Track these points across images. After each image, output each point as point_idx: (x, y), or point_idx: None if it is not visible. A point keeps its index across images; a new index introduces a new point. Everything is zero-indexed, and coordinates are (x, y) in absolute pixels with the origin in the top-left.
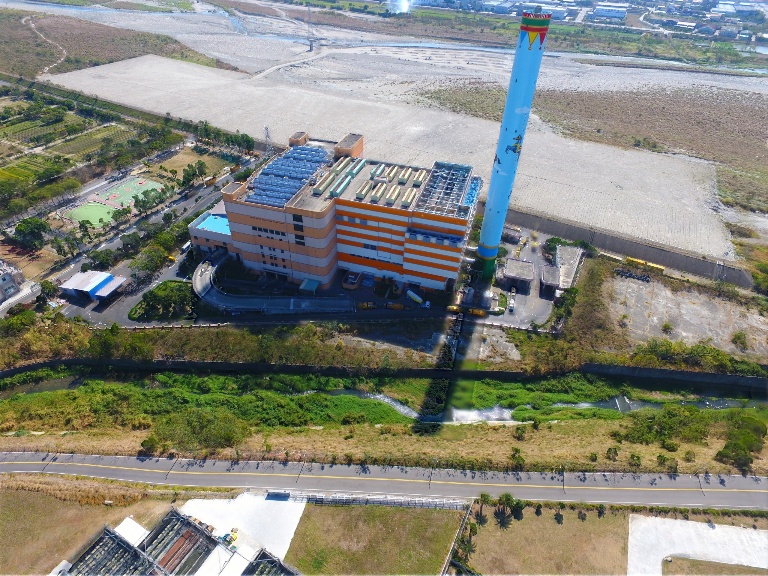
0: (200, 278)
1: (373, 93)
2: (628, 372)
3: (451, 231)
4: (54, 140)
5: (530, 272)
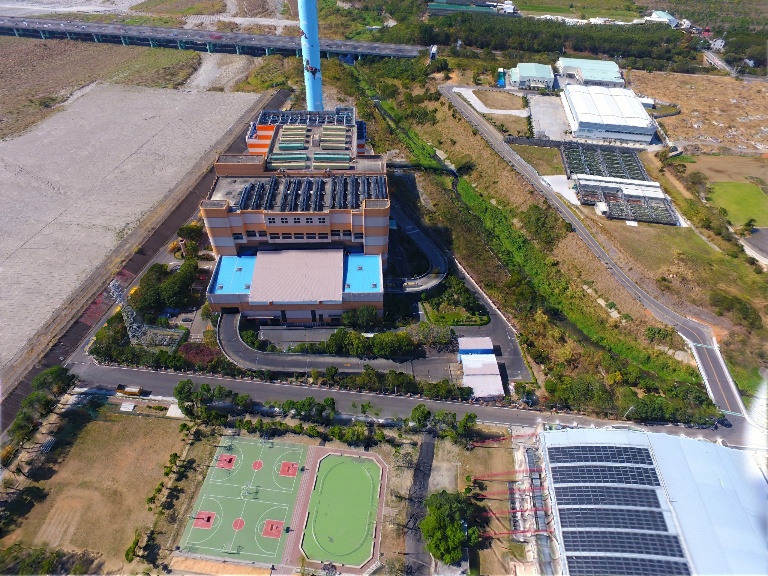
0: (425, 284)
1: None
2: None
3: None
4: None
5: None
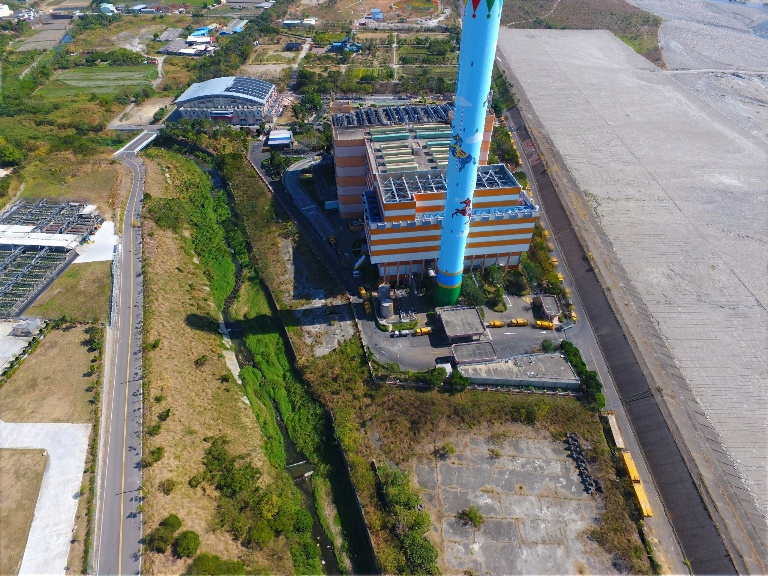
0: (305, 162)
1: None
2: None
3: None
4: (412, 63)
5: (463, 332)
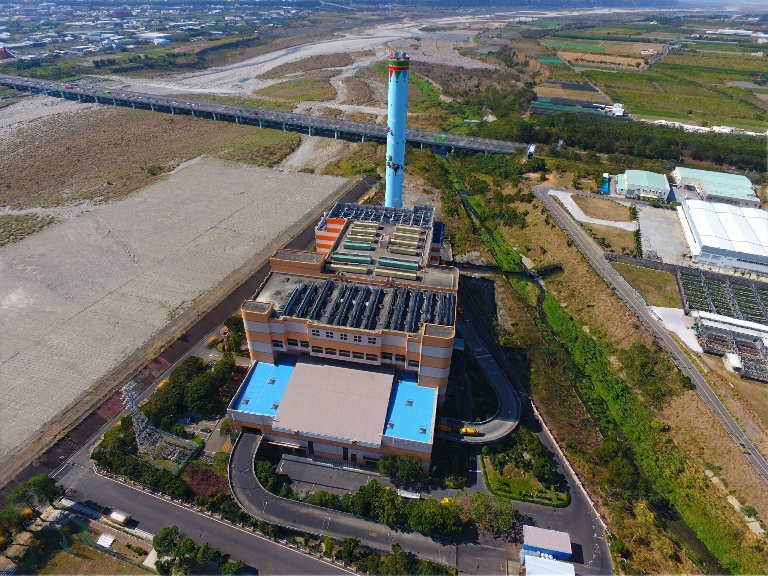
0: (488, 434)
1: None
2: None
3: None
4: None
5: None
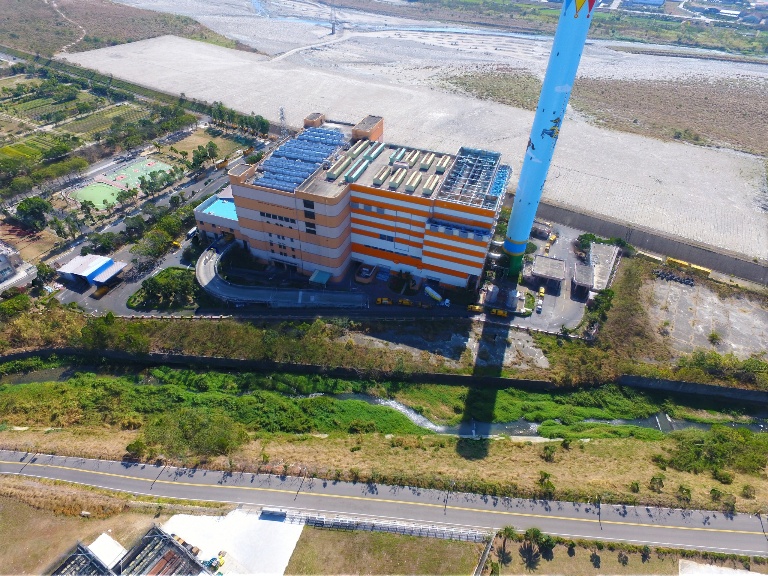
0: (204, 266)
1: (395, 78)
2: (670, 387)
3: (476, 223)
4: (65, 118)
5: (561, 271)
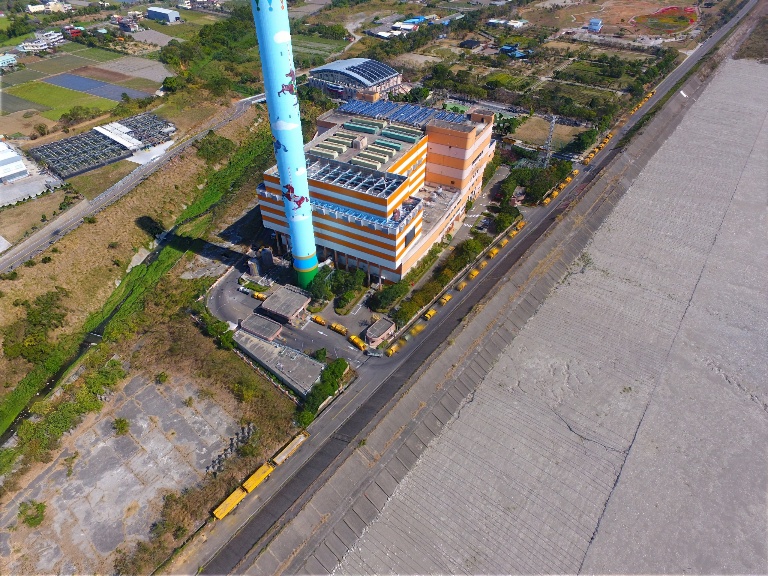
0: None
1: None
2: None
3: None
4: (563, 79)
5: (275, 309)
